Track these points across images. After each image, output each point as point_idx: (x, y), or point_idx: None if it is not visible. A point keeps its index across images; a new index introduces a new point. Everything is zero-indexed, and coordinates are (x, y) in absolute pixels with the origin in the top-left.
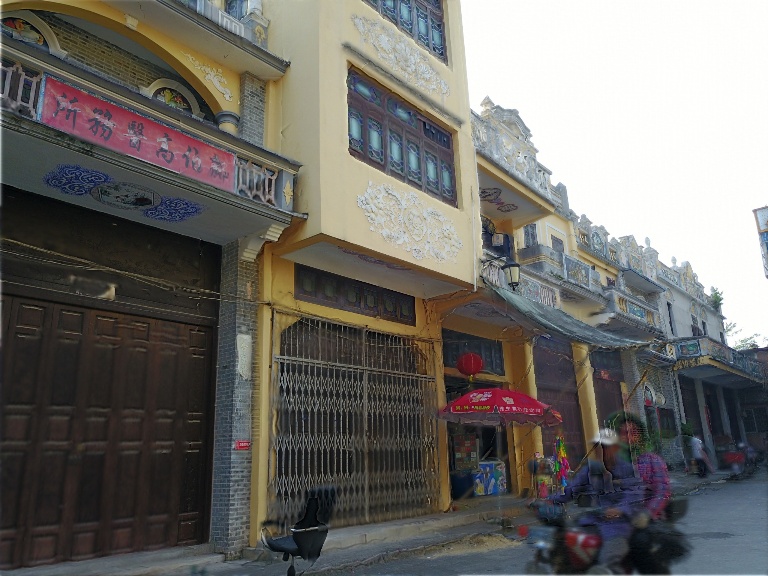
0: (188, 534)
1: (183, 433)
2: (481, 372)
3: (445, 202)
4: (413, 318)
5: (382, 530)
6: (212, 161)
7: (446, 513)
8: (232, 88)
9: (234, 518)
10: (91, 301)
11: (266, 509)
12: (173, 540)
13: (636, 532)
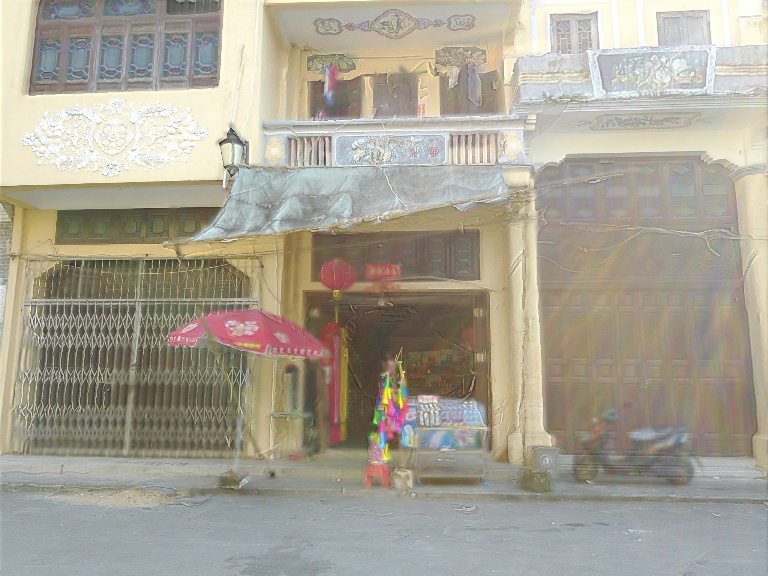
0: None
1: None
2: (417, 280)
3: (197, 86)
4: None
5: (89, 464)
6: None
7: (253, 460)
8: None
9: None
10: None
11: None
12: None
13: (293, 532)
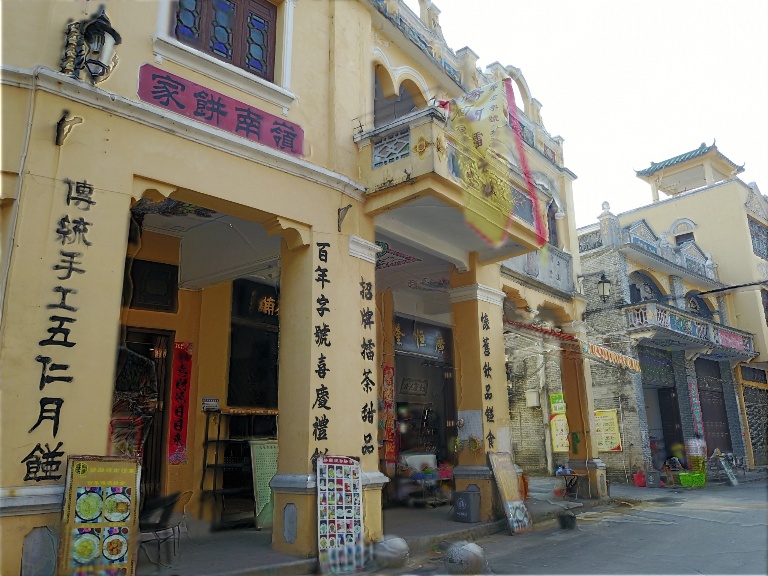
0: None
1: None
2: None
3: None
4: (766, 380)
5: None
6: None
7: None
8: None
9: (746, 458)
10: None
11: None
12: None
13: None
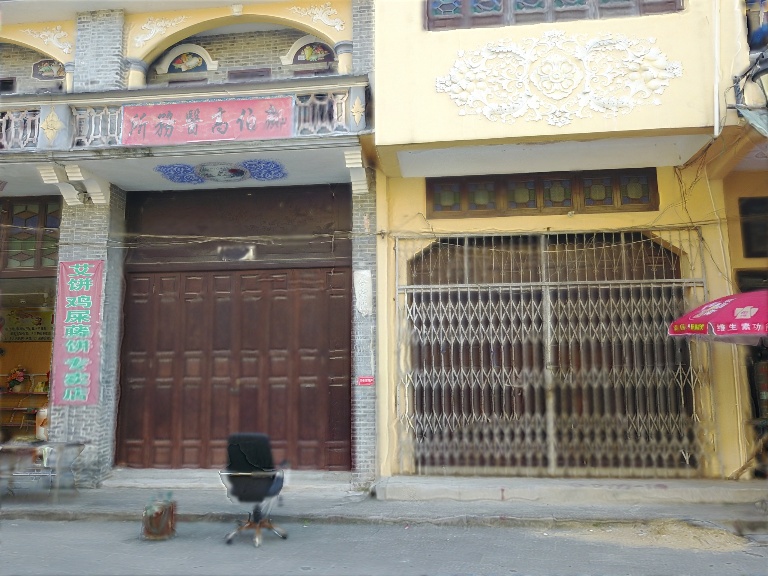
0: (335, 460)
1: (325, 369)
2: None
3: (649, 12)
4: (655, 199)
5: (536, 488)
6: (268, 113)
7: (725, 480)
8: (344, 14)
9: (357, 451)
10: (233, 264)
11: (387, 446)
12: (320, 464)
13: None
